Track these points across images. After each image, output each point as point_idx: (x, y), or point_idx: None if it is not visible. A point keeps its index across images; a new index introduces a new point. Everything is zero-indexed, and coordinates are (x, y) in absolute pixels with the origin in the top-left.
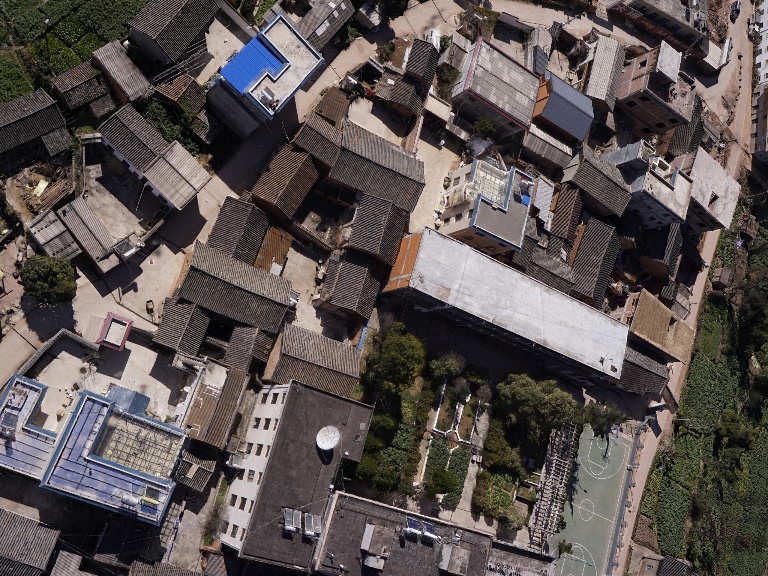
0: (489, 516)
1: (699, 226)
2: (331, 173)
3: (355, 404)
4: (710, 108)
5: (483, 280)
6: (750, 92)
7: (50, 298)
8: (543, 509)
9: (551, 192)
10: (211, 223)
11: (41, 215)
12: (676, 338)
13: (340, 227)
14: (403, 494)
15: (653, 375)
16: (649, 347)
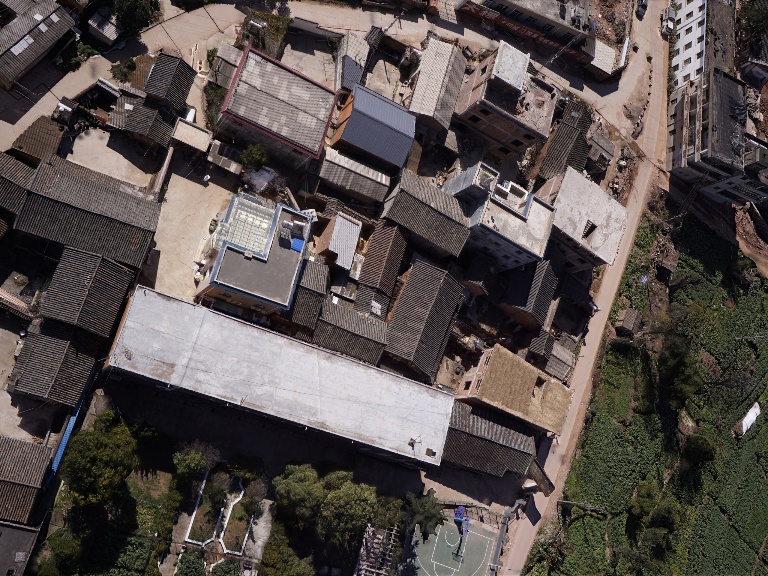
0: None
1: (580, 262)
2: (16, 224)
3: (9, 527)
4: (607, 120)
5: (227, 350)
6: (665, 99)
7: None
8: None
9: (357, 231)
10: None
11: None
12: (545, 403)
13: None
14: None
15: (513, 451)
16: (511, 415)
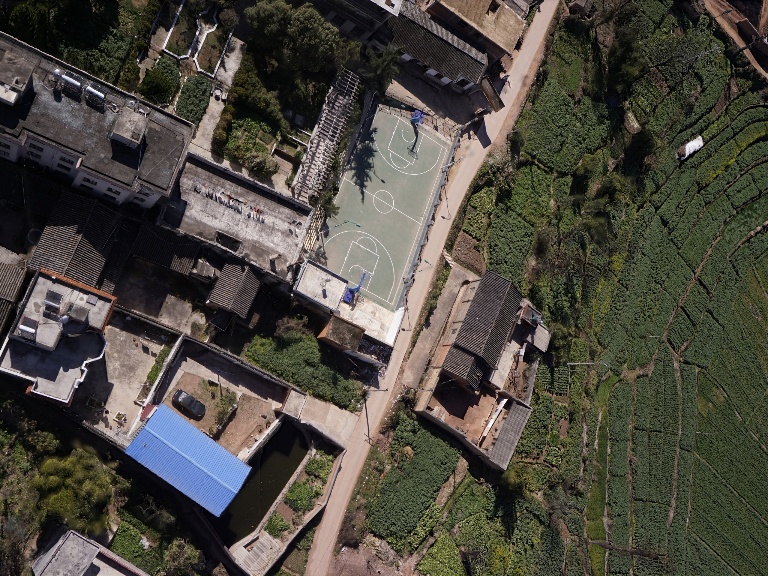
0: (236, 162)
1: None
2: None
3: None
4: None
5: None
6: None
7: None
8: None
9: None
10: None
11: None
12: (498, 23)
13: None
14: None
15: (467, 57)
16: (466, 32)
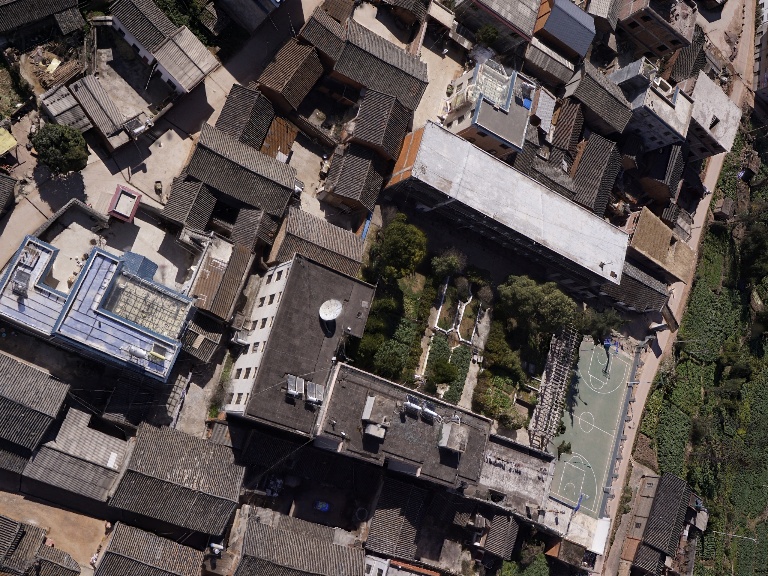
0: (489, 416)
1: (700, 151)
2: (336, 66)
3: (357, 282)
4: (713, 42)
5: (484, 176)
6: (753, 31)
7: (62, 165)
8: (543, 412)
9: (553, 104)
10: (218, 113)
11: (54, 89)
12: (676, 257)
13: (344, 124)
14: (404, 383)
15: (653, 292)
16: (650, 266)
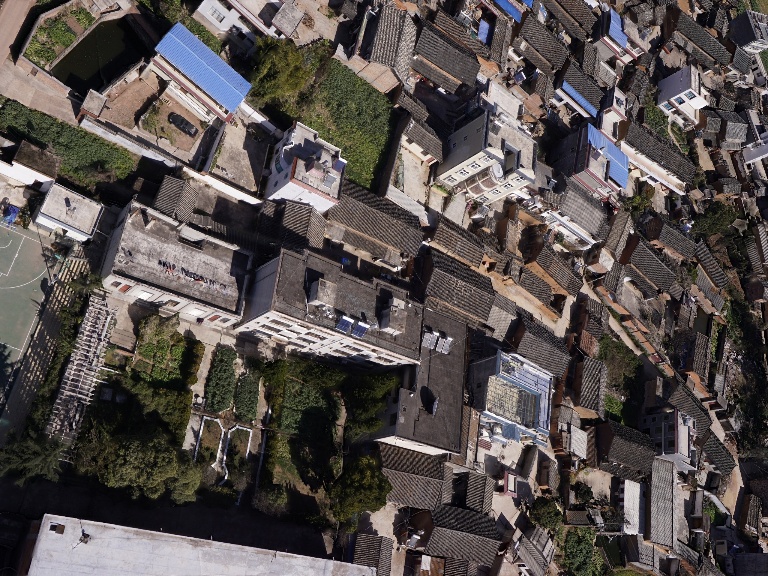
0: None
1: None
2: None
3: (410, 439)
4: None
5: None
6: None
7: None
8: None
9: None
10: None
11: None
12: None
13: None
14: None
15: None
16: None
